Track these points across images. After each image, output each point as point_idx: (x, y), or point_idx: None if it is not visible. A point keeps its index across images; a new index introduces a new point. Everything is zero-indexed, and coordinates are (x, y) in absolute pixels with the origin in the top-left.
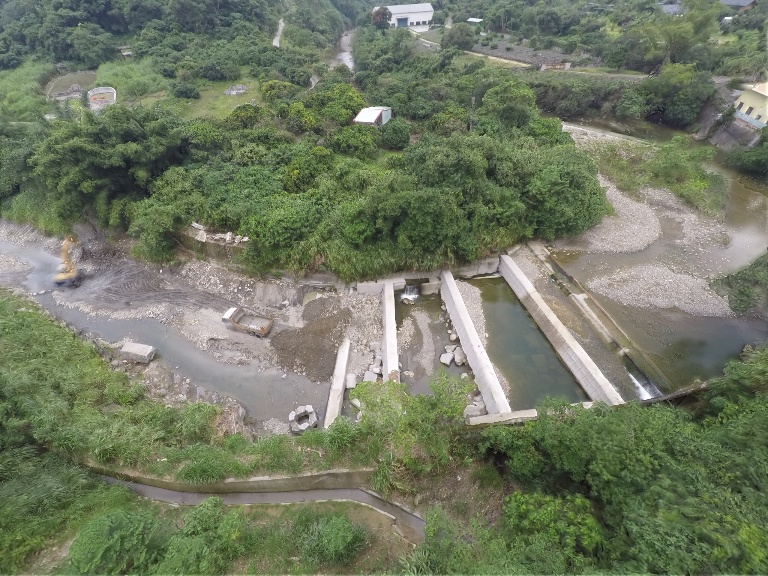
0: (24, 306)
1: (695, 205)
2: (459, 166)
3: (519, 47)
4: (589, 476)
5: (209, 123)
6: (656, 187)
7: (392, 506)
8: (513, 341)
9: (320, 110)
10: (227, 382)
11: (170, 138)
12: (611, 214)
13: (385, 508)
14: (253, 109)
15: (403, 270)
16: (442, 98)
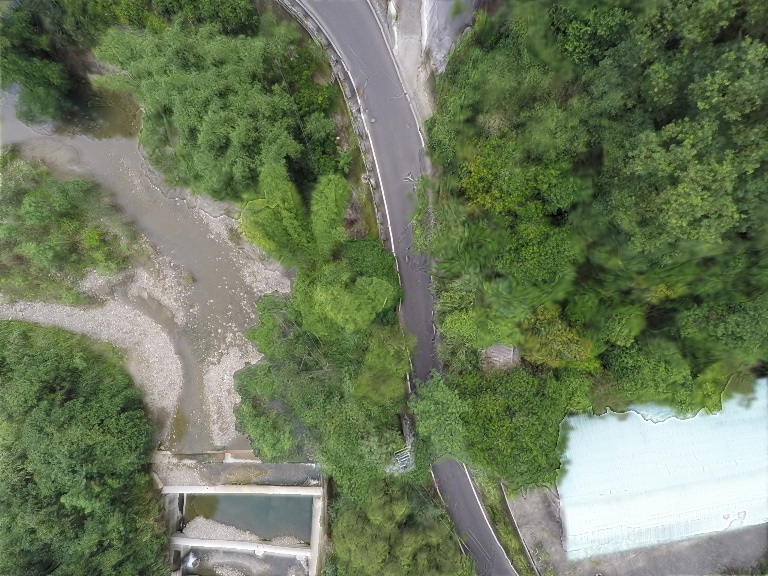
0: None
1: (123, 266)
2: None
3: None
4: None
5: None
6: (78, 278)
7: None
8: (256, 509)
9: None
10: None
11: None
12: (120, 360)
13: None
14: None
15: None
16: None
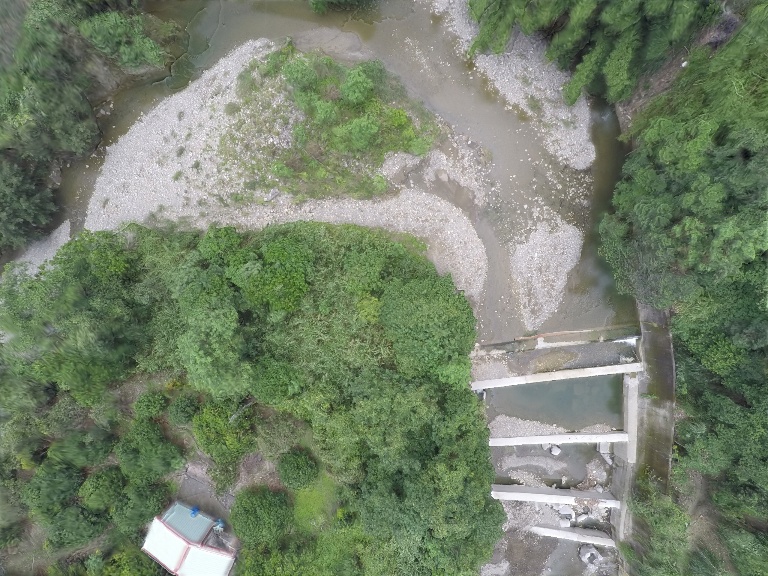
0: None
1: None
2: None
3: None
4: None
5: None
6: (380, 163)
7: None
8: (557, 402)
9: None
10: None
11: None
12: (425, 249)
13: None
14: None
15: None
16: None
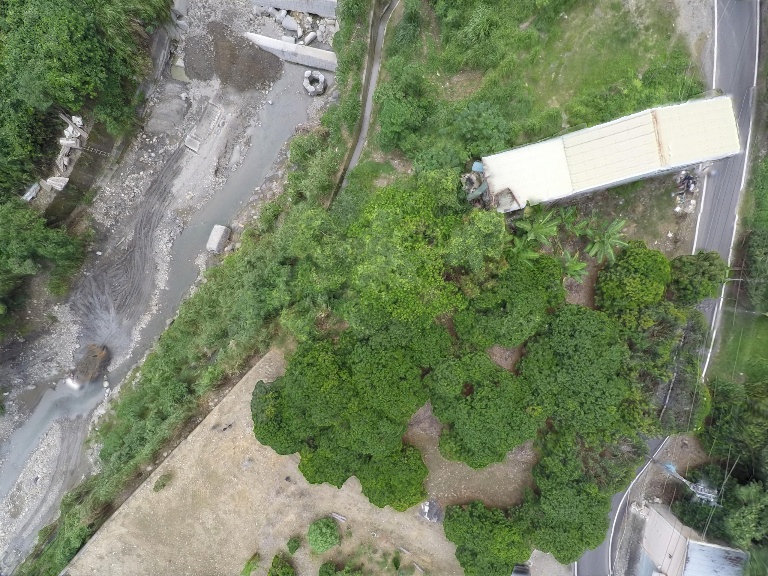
0: (130, 383)
1: None
2: None
3: None
4: None
5: None
6: None
7: None
8: None
9: None
10: (265, 154)
11: None
12: None
13: (395, 2)
14: None
15: None
16: None
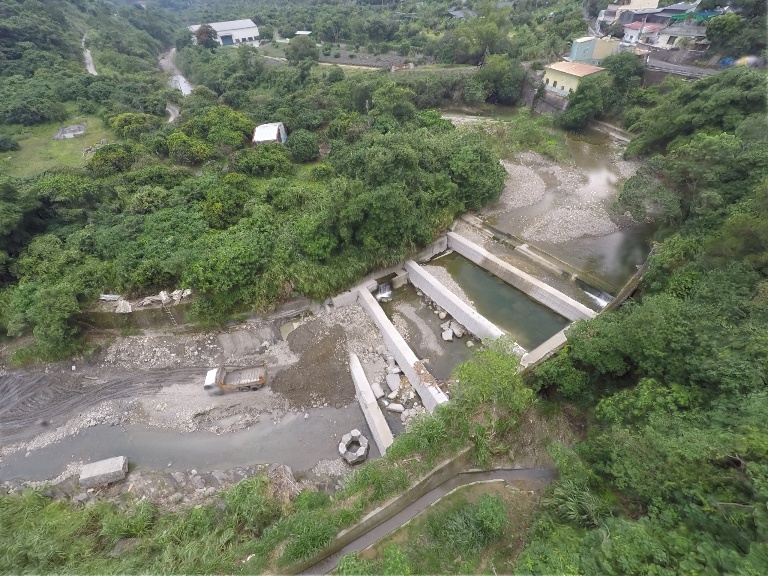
0: None
1: (555, 158)
2: (397, 161)
3: (360, 54)
4: (642, 363)
5: (65, 175)
6: (524, 151)
7: (495, 472)
8: (492, 300)
9: (203, 137)
10: (244, 451)
11: (25, 202)
12: (507, 178)
13: (491, 477)
14: (123, 148)
15: (371, 272)
16: (324, 107)
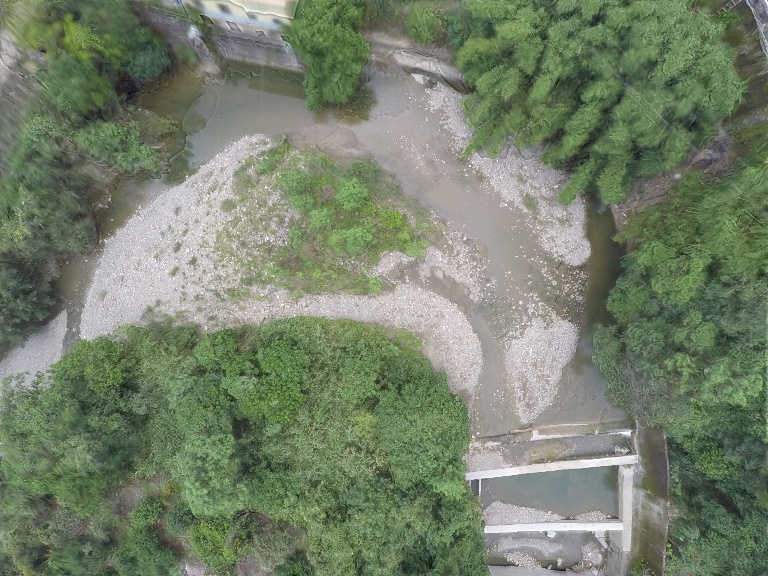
0: None
1: None
2: None
3: None
4: None
5: None
6: (376, 262)
7: None
8: (552, 488)
9: None
10: None
11: None
12: (420, 345)
13: None
14: None
15: None
16: None
